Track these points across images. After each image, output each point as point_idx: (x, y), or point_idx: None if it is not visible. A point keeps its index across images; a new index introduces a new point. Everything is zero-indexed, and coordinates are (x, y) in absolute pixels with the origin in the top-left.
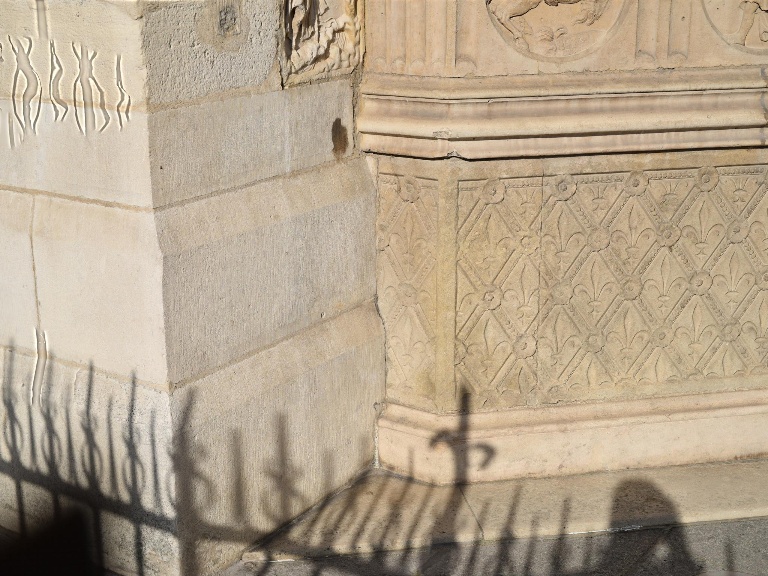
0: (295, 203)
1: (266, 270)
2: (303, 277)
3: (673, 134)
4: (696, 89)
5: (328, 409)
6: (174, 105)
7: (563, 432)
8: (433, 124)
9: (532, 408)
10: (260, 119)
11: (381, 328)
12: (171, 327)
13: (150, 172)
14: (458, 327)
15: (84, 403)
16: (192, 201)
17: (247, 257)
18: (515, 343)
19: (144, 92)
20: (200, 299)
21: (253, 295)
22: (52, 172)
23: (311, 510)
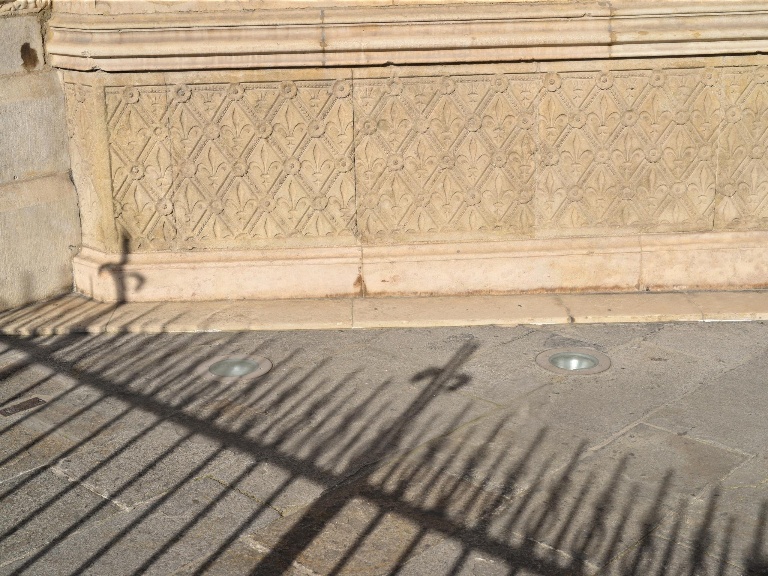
0: None
1: None
2: None
3: (257, 56)
4: (270, 24)
5: (21, 243)
6: None
7: (193, 269)
8: (82, 47)
9: (174, 252)
10: None
11: (73, 192)
12: None
13: None
14: (115, 191)
15: None
16: None
17: None
18: (158, 204)
19: None
20: None
21: None
22: None
23: (8, 311)
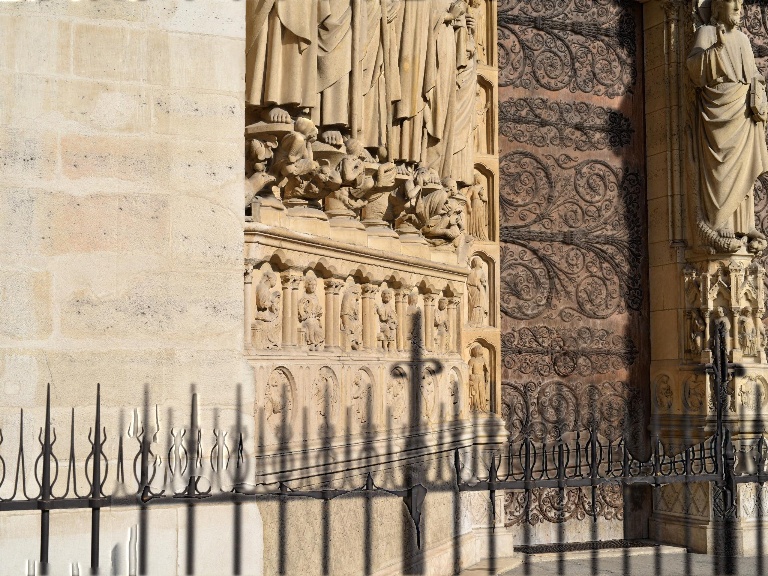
0: None
1: None
2: None
3: None
4: None
5: None
6: None
7: None
8: (256, 468)
9: None
10: None
11: None
12: None
13: None
14: None
15: None
16: None
17: None
18: None
19: None
20: None
21: None
22: None
23: None
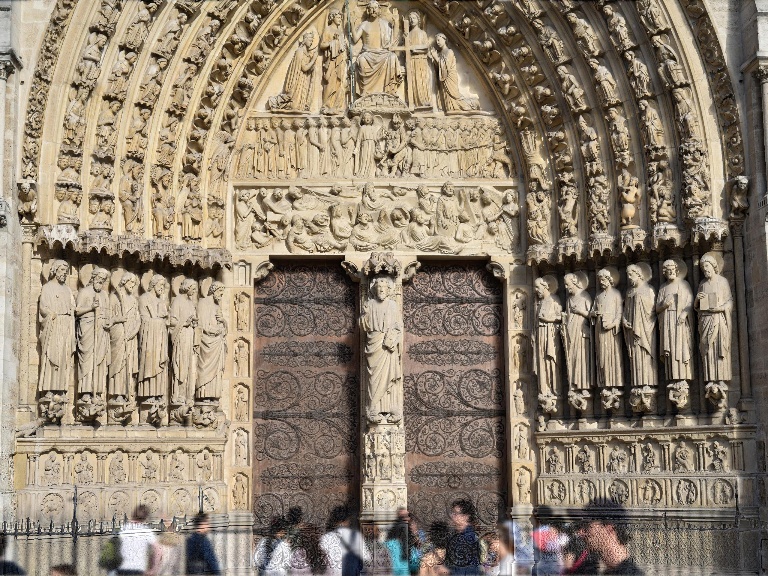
0: None
1: None
2: None
3: None
4: None
5: None
6: None
7: None
8: None
9: None
10: None
11: (19, 575)
12: None
13: None
14: (36, 572)
15: None
16: None
17: None
18: None
19: None
20: None
21: None
22: None
23: None
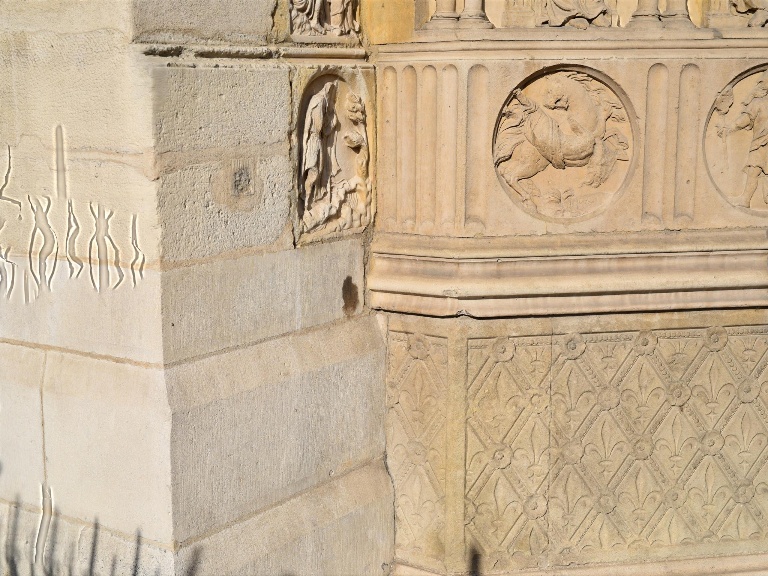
0: (305, 360)
1: (275, 427)
2: (312, 434)
3: (681, 294)
4: (703, 250)
5: (335, 570)
6: (187, 263)
7: None
8: (443, 283)
9: (543, 570)
10: (272, 277)
11: (390, 486)
12: (178, 484)
13: (162, 329)
14: (468, 486)
15: (87, 562)
16: (202, 358)
17: (256, 414)
18: (525, 503)
19: (158, 251)
20: (208, 456)
21: (261, 452)
22: (65, 328)
23: None
